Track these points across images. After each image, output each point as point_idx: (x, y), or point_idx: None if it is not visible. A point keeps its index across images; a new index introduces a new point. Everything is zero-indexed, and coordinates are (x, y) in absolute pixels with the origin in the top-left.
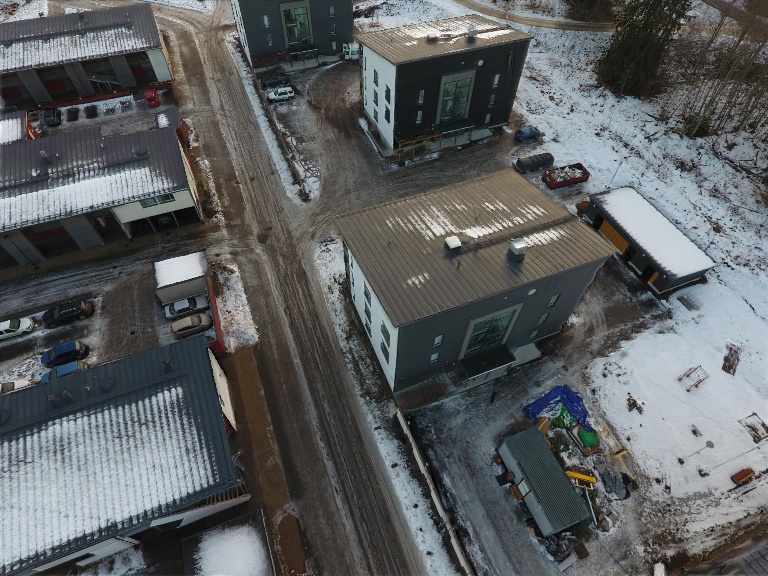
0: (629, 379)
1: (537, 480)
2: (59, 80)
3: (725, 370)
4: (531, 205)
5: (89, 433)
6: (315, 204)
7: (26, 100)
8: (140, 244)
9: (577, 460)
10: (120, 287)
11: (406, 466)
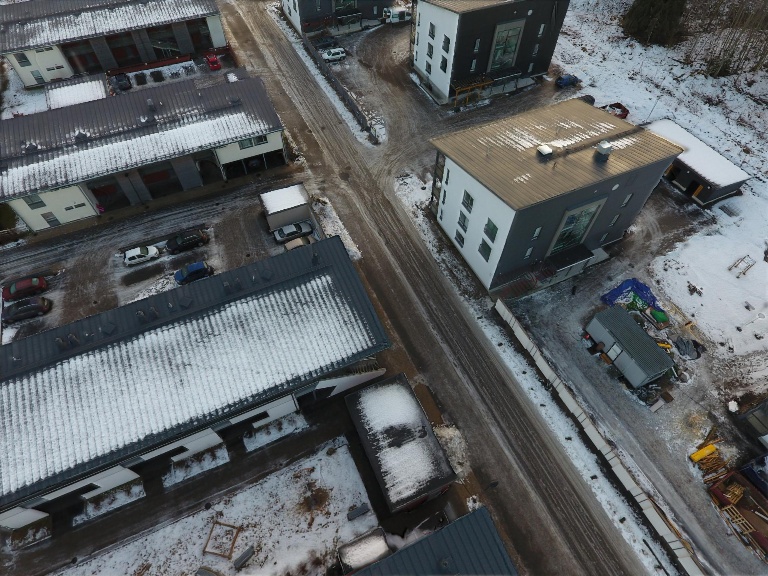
0: (687, 271)
1: (627, 342)
2: (123, 48)
3: (766, 261)
4: (601, 122)
5: (261, 312)
6: (385, 146)
7: (93, 68)
8: (235, 184)
9: (653, 333)
10: (227, 219)
11: (510, 345)
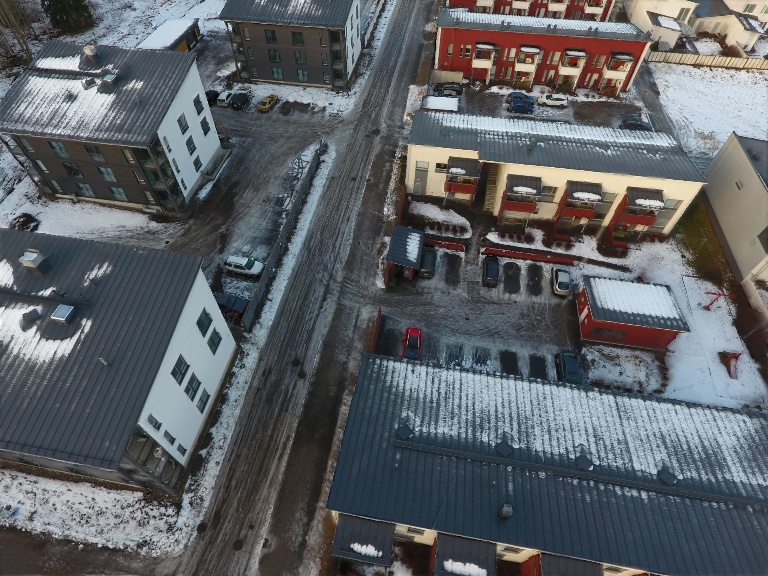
0: None
1: None
2: None
3: None
4: None
5: None
6: None
7: None
8: None
9: None
10: None
11: None
